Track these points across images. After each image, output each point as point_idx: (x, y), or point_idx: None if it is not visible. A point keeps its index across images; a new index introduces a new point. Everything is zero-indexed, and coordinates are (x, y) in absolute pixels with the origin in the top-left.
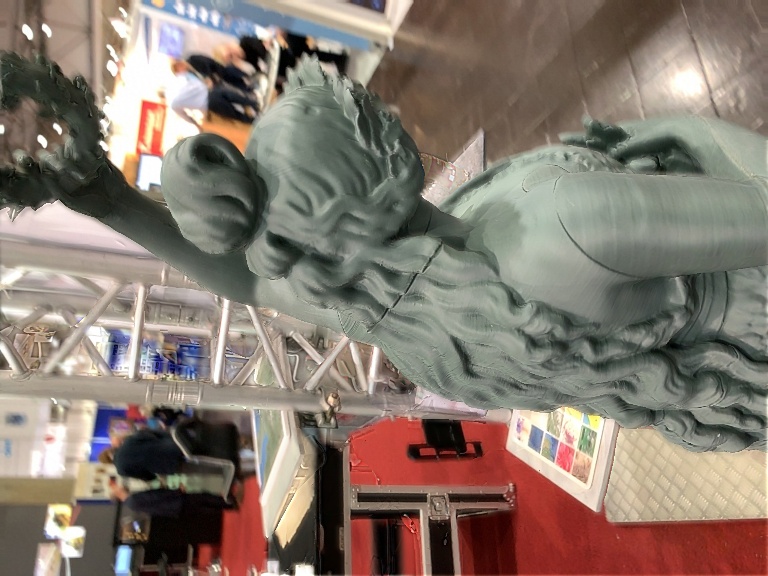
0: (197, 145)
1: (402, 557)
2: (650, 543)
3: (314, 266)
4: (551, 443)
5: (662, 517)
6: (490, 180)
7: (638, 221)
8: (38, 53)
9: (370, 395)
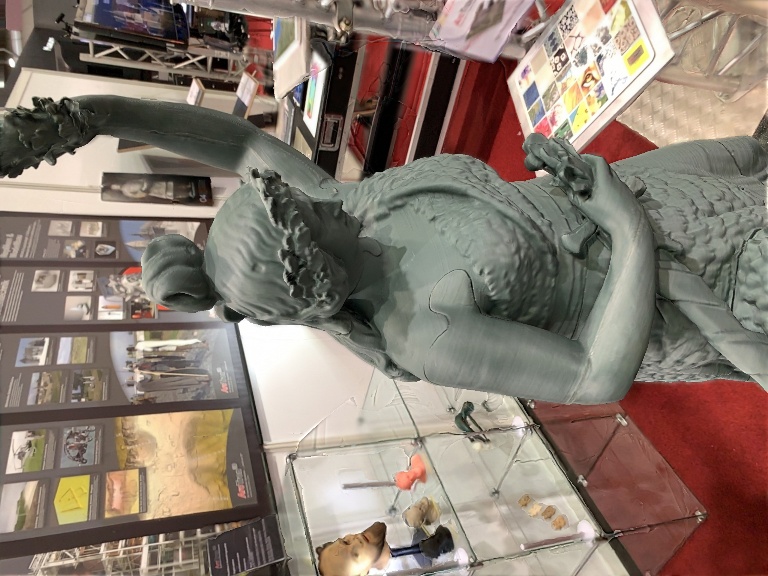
0: (166, 296)
1: (409, 67)
2: (617, 139)
3: (259, 322)
4: (539, 111)
5: (637, 129)
6: (446, 193)
7: None
8: (5, 118)
9: (386, 19)
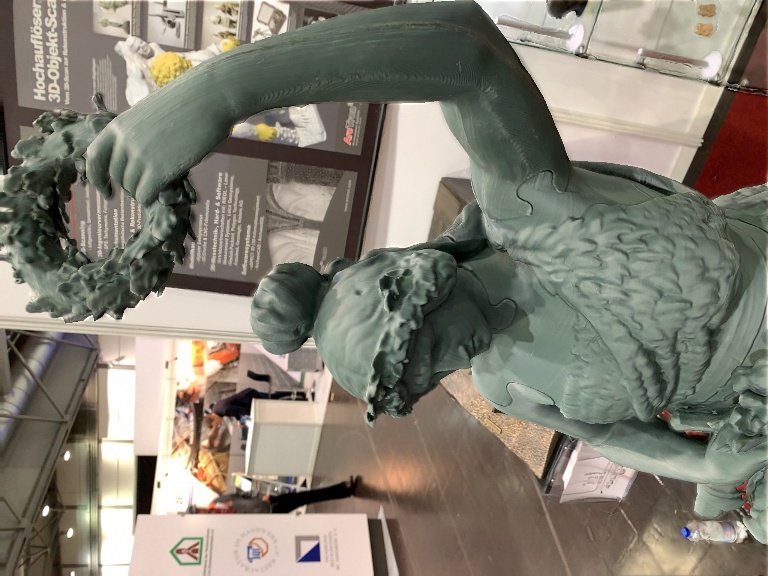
0: None
1: None
2: None
3: None
4: None
5: None
6: None
7: None
8: None
9: None
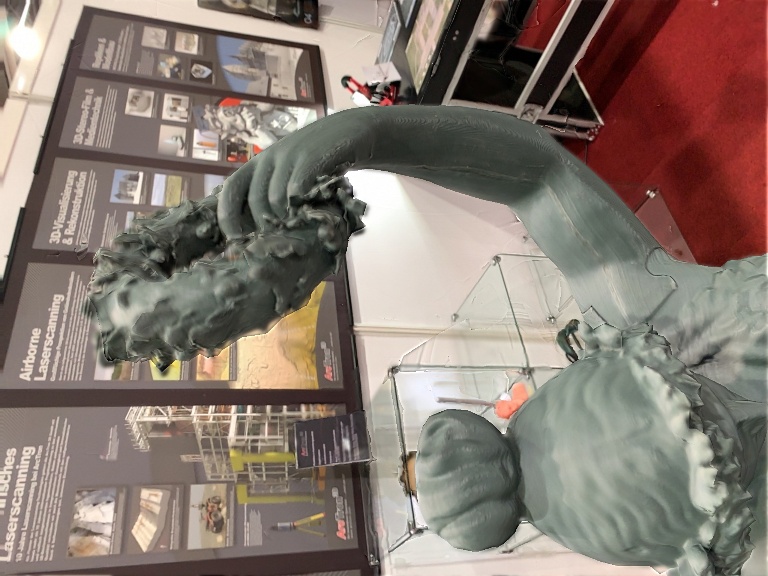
0: None
1: None
2: None
3: None
4: None
5: None
6: None
7: None
8: (257, 276)
9: None
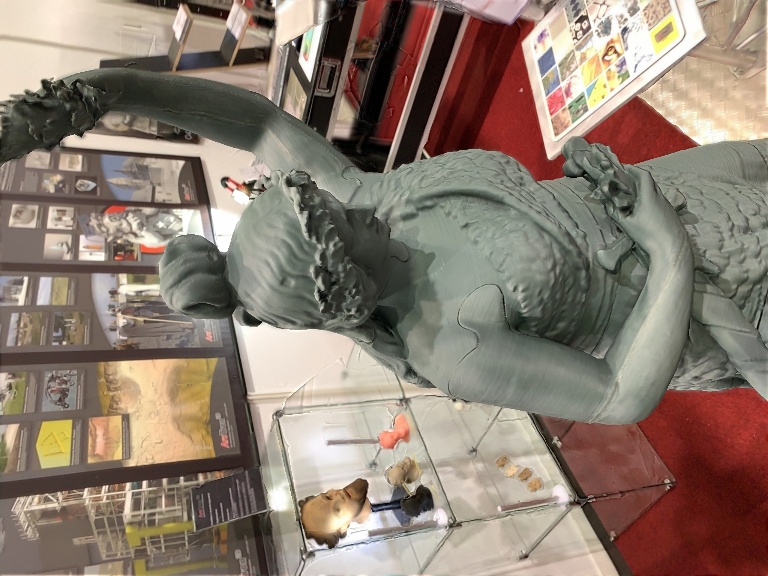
0: None
1: (413, 12)
2: None
3: None
4: (554, 79)
5: (645, 97)
6: (480, 198)
7: (498, 402)
8: (14, 108)
9: None
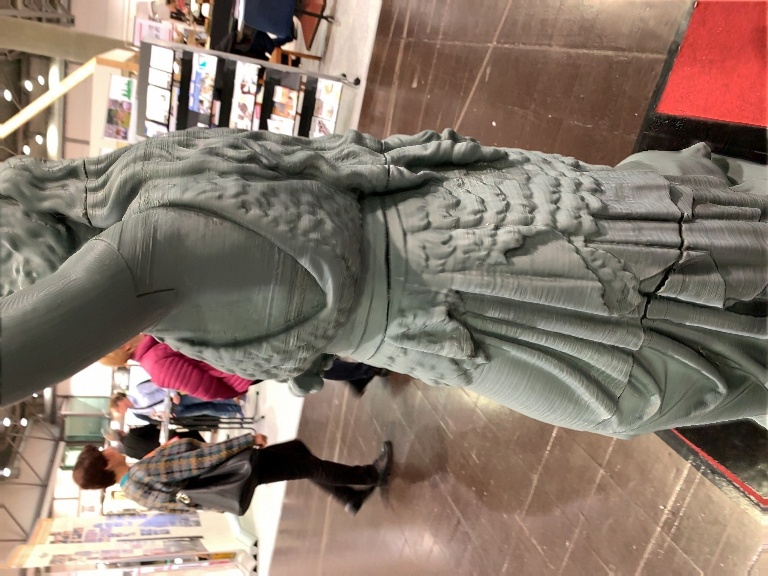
0: None
1: None
2: None
3: None
4: None
5: None
6: None
7: None
8: None
9: None
